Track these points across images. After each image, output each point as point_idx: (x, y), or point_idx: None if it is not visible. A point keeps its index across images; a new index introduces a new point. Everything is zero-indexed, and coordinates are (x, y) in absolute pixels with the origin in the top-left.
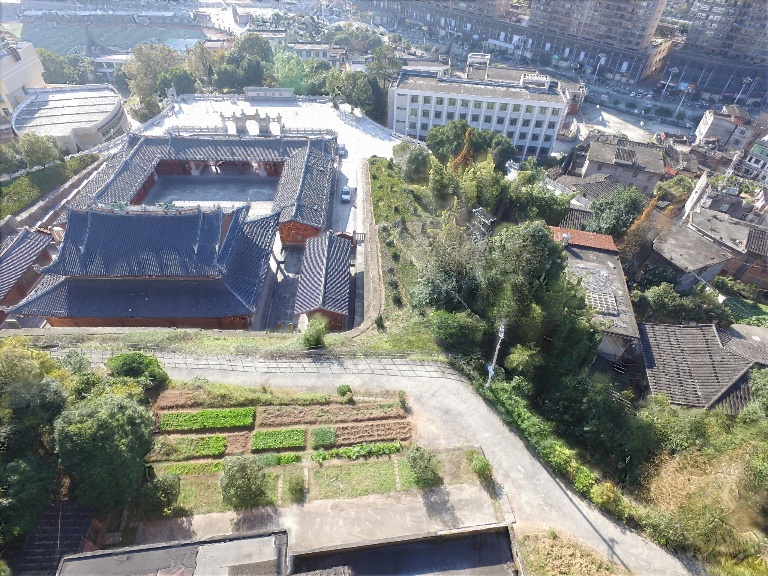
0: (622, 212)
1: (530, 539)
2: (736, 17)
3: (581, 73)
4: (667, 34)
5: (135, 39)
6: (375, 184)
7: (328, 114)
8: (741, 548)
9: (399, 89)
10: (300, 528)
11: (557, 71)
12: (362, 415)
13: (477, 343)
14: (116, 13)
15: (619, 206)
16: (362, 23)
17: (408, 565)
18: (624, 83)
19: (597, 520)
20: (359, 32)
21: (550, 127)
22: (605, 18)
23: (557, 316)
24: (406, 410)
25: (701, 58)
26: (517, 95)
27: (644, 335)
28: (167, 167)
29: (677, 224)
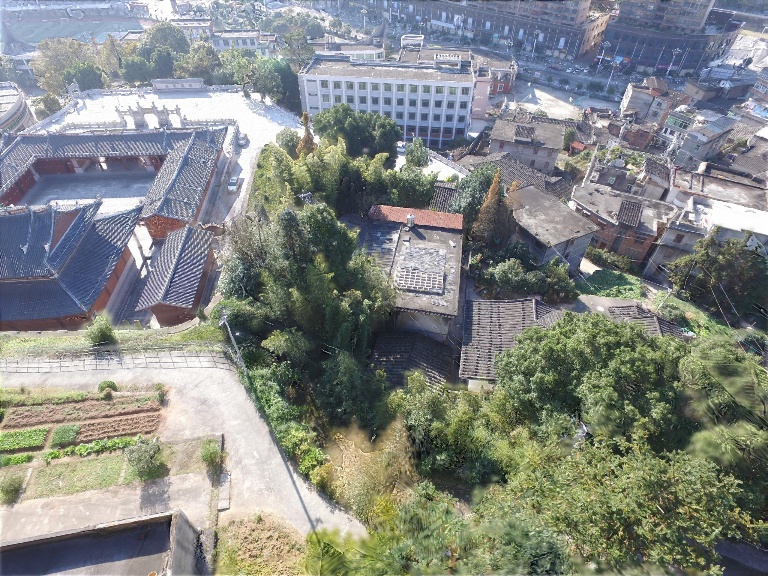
0: (476, 190)
1: (234, 524)
2: None
3: (520, 51)
4: (606, 8)
5: (67, 34)
6: (257, 173)
7: (237, 104)
8: (431, 519)
9: (307, 75)
10: (1, 529)
11: (491, 50)
12: (114, 410)
13: (254, 331)
14: (49, 7)
15: (474, 184)
16: (303, 8)
17: (62, 560)
18: (562, 59)
19: (311, 501)
20: (298, 18)
21: (462, 107)
22: None
23: (322, 299)
24: (162, 402)
25: (633, 31)
26: (427, 76)
27: (469, 312)
28: (48, 166)
29: (551, 199)
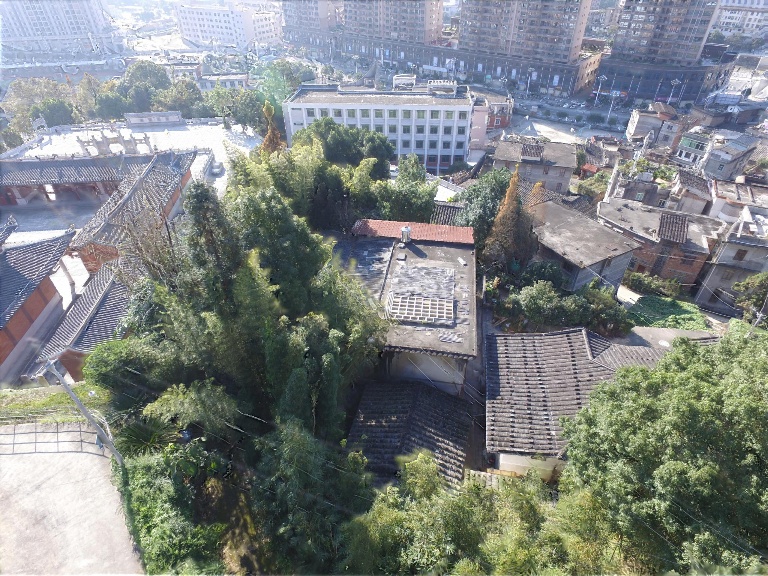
0: (488, 198)
1: None
2: (657, 23)
3: (514, 90)
4: (597, 48)
5: None
6: None
7: (216, 135)
8: None
9: (292, 103)
10: None
11: (485, 87)
12: None
13: (153, 386)
14: (44, 65)
15: (485, 191)
16: (295, 58)
17: None
18: (558, 96)
19: None
20: None
21: (460, 132)
22: (530, 34)
23: (261, 330)
24: None
25: (629, 65)
26: (421, 101)
27: (492, 351)
28: None
29: (576, 215)
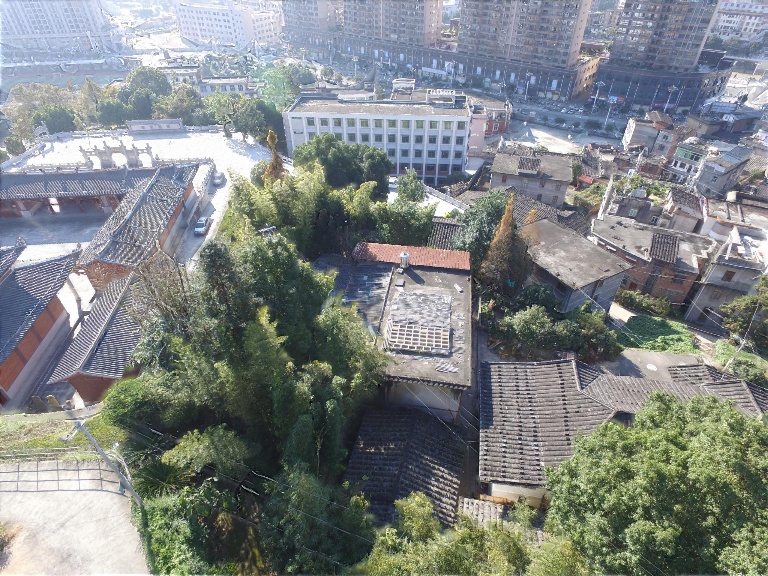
0: (484, 222)
1: None
2: (655, 29)
3: (513, 94)
4: (595, 52)
5: None
6: (228, 212)
7: (217, 143)
8: None
9: (292, 112)
10: None
11: (484, 91)
12: None
13: (167, 426)
14: (43, 63)
15: (481, 215)
16: (294, 59)
17: None
18: (556, 101)
19: None
20: (289, 67)
21: (458, 142)
22: (529, 39)
23: (269, 377)
24: None
25: (626, 71)
26: (420, 111)
27: (486, 380)
28: None
29: (570, 234)
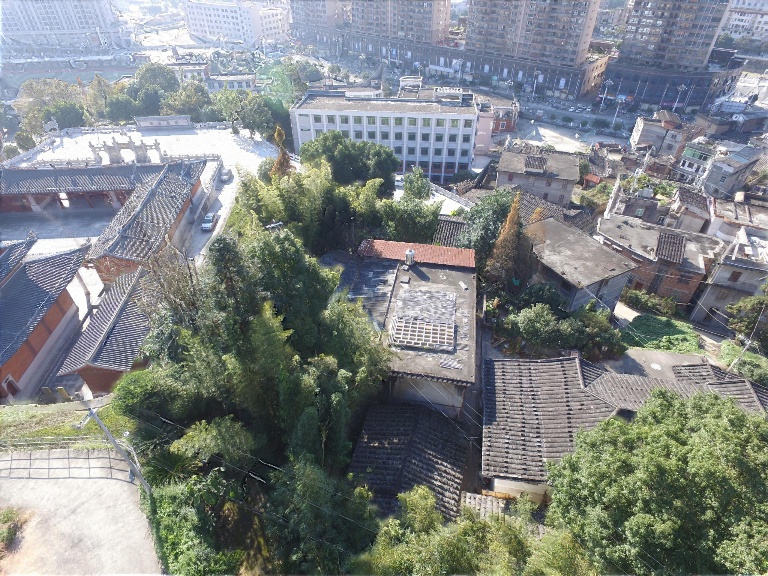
0: (490, 220)
1: None
2: (665, 28)
3: (520, 92)
4: (604, 51)
5: None
6: (235, 208)
7: (225, 140)
8: None
9: (299, 109)
10: None
11: (491, 90)
12: None
13: (175, 417)
14: (52, 59)
15: (487, 213)
16: (302, 56)
17: None
18: (564, 99)
19: None
20: (297, 64)
21: (465, 140)
22: (538, 37)
23: (276, 370)
24: (10, 544)
25: (635, 70)
26: (427, 109)
27: (490, 376)
28: (2, 203)
29: (576, 232)
